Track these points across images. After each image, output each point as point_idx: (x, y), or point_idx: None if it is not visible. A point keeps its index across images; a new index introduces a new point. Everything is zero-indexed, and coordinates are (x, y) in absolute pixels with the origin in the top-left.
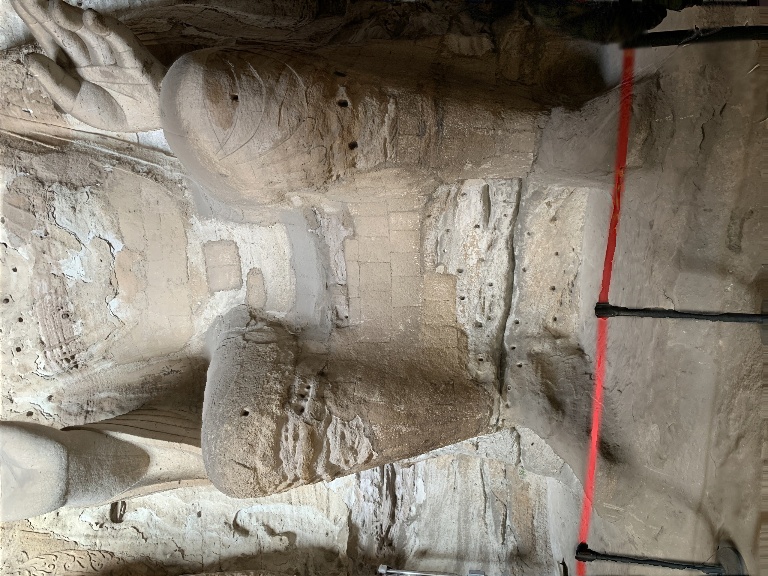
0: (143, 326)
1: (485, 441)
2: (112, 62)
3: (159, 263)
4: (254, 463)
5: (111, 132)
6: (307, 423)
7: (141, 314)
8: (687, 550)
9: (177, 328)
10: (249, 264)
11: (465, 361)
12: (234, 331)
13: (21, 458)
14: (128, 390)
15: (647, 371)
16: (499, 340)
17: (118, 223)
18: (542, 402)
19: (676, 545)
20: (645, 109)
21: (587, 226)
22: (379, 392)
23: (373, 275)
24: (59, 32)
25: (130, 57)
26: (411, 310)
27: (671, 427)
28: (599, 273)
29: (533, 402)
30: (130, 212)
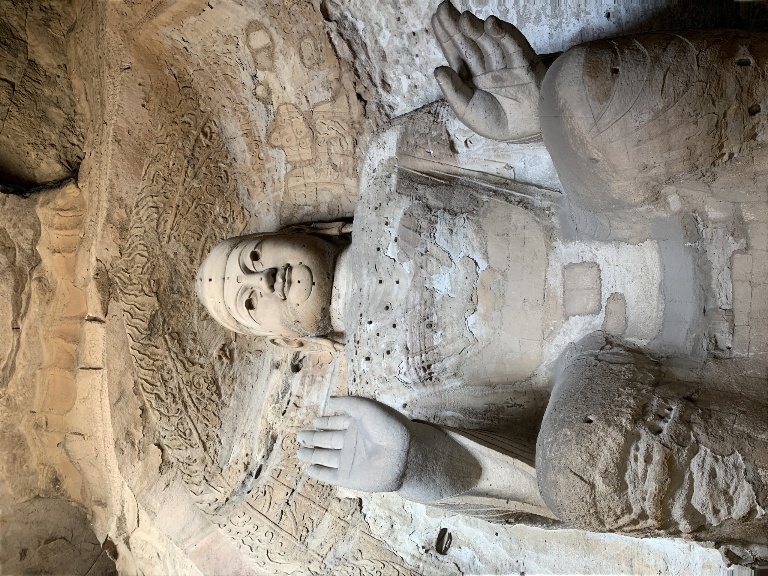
0: (494, 346)
1: None
2: (503, 66)
3: (518, 283)
4: (593, 478)
5: (492, 170)
6: (664, 445)
7: (494, 333)
8: None
9: (526, 353)
10: (611, 288)
11: None
12: (586, 354)
13: (373, 432)
14: (471, 414)
15: None
16: None
17: (486, 245)
18: None
19: None
20: None
21: None
22: None
23: None
24: (464, 44)
25: (519, 57)
26: None
27: None
28: None
29: None
30: (498, 235)
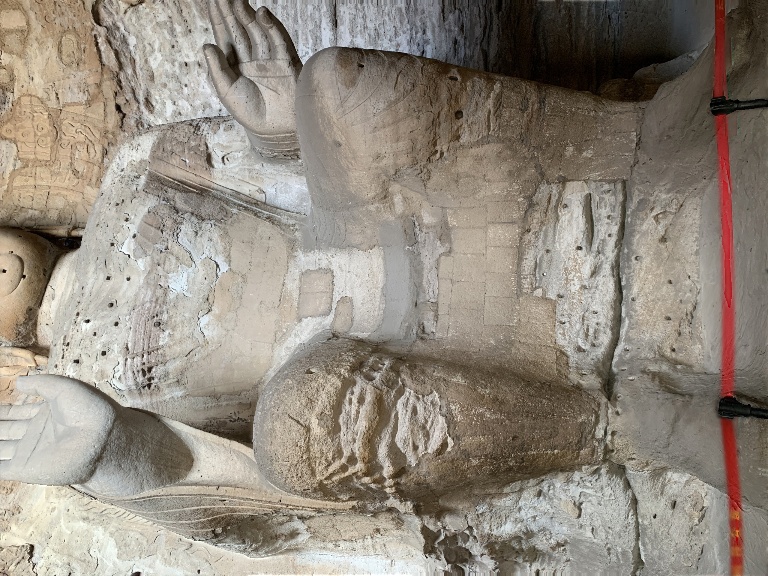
0: (225, 349)
1: (590, 501)
2: (268, 57)
3: (257, 286)
4: (309, 421)
5: (245, 191)
6: (376, 388)
7: (226, 335)
8: None
9: (257, 356)
10: (341, 292)
11: (565, 373)
12: None
13: (70, 411)
14: None
15: None
16: (606, 368)
17: (230, 249)
18: (662, 396)
19: None
20: (745, 12)
21: (702, 247)
22: (462, 375)
23: (466, 294)
24: (235, 28)
25: (283, 50)
26: (504, 328)
27: None
28: (721, 280)
29: (650, 400)
30: (243, 242)
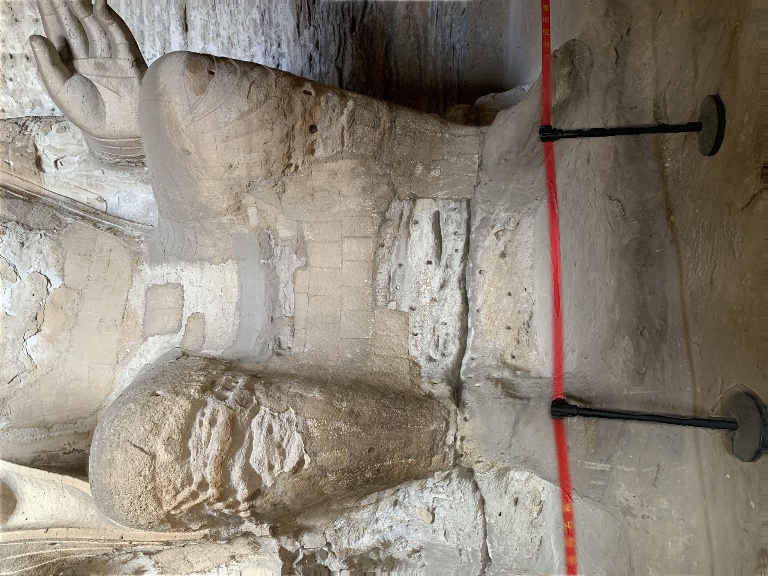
0: (57, 373)
1: (443, 505)
2: (107, 56)
3: (96, 302)
4: (154, 448)
5: (82, 199)
6: (229, 407)
7: (59, 357)
8: (694, 481)
9: (95, 380)
10: (192, 308)
11: (417, 383)
12: None
13: None
14: None
15: (608, 295)
16: (455, 376)
17: (64, 263)
18: (504, 401)
19: (679, 481)
20: (566, 52)
21: (536, 262)
22: (318, 390)
23: (322, 308)
24: (69, 20)
25: (125, 49)
26: (360, 341)
27: (643, 332)
28: (552, 292)
29: (494, 405)
30: (79, 255)
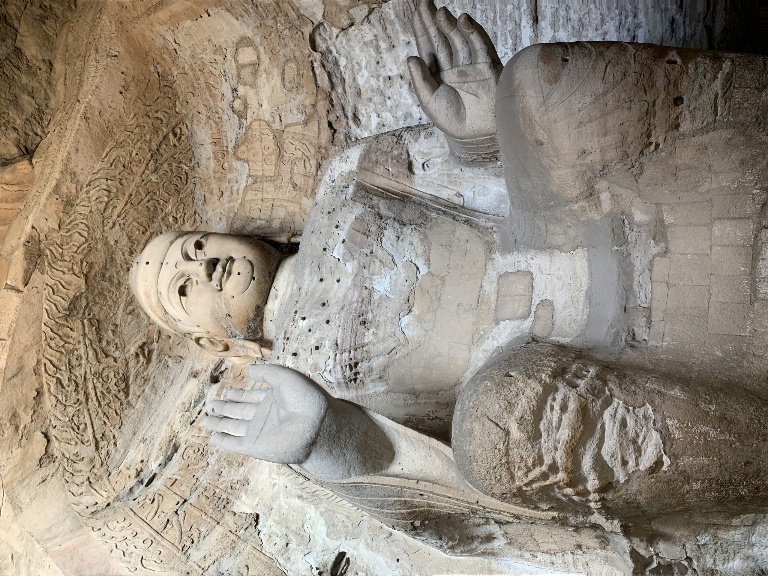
0: (424, 349)
1: None
2: (468, 63)
3: (455, 288)
4: (508, 425)
5: (444, 196)
6: (580, 395)
7: (426, 335)
8: None
9: (454, 357)
10: (541, 295)
11: None
12: None
13: (290, 398)
14: None
15: None
16: None
17: (429, 253)
18: None
19: None
20: None
21: None
22: (680, 388)
23: (685, 298)
24: (437, 37)
25: (484, 53)
26: (734, 338)
27: None
28: None
29: None
30: (442, 246)
